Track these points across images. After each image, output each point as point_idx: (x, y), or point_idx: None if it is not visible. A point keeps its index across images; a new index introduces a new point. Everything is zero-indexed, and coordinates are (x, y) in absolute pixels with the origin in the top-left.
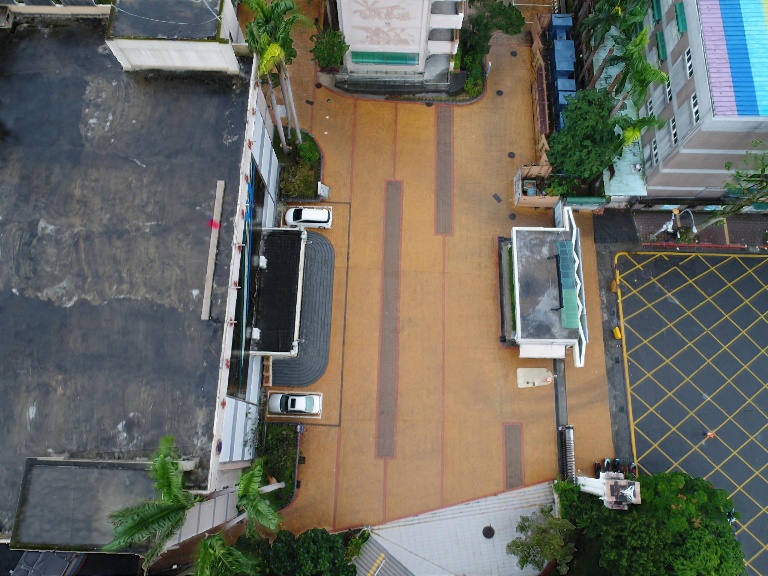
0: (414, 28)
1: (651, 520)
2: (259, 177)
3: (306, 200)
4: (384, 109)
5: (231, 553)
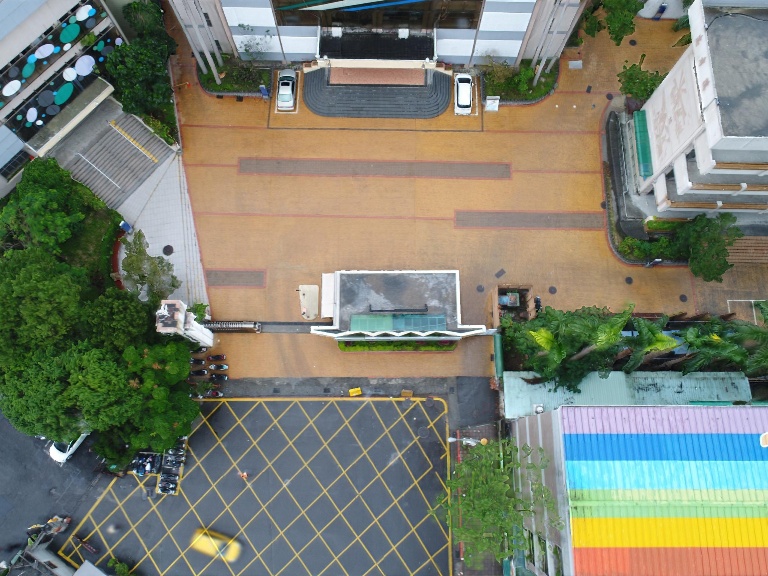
0: (672, 149)
1: (137, 329)
2: (479, 11)
3: (482, 91)
4: (592, 160)
5: None
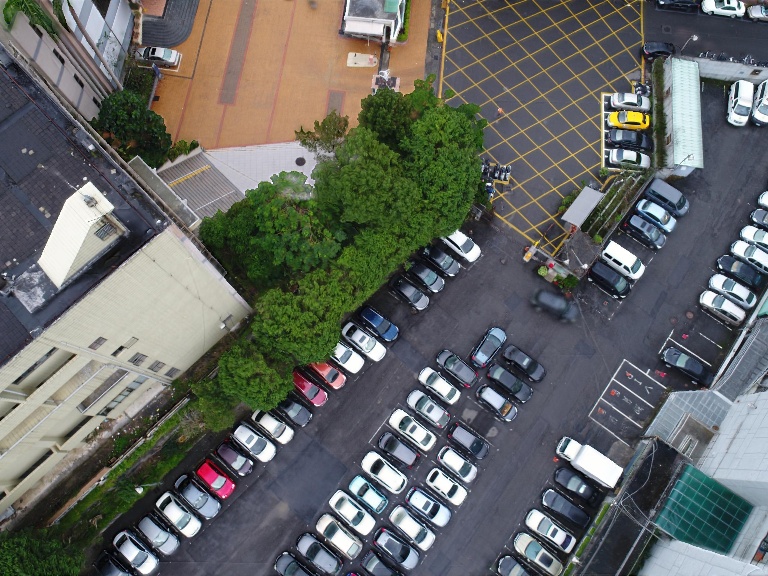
0: None
1: None
2: None
3: None
4: None
5: (34, 4)
